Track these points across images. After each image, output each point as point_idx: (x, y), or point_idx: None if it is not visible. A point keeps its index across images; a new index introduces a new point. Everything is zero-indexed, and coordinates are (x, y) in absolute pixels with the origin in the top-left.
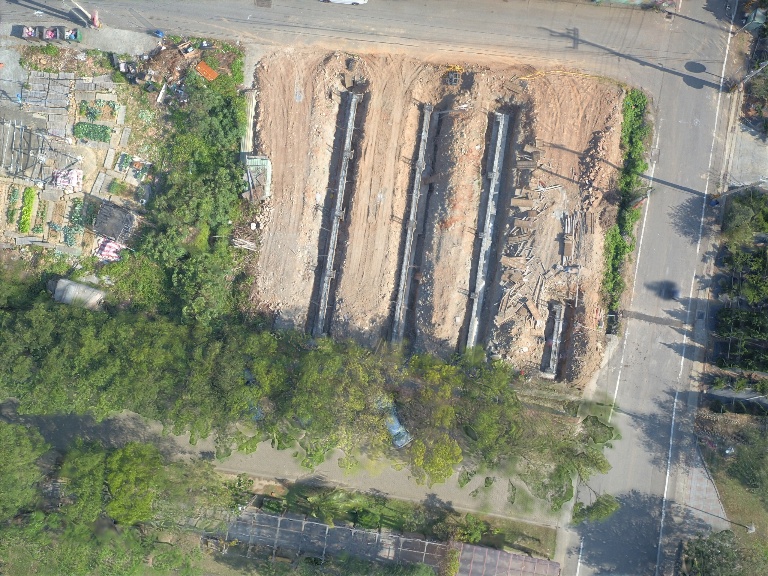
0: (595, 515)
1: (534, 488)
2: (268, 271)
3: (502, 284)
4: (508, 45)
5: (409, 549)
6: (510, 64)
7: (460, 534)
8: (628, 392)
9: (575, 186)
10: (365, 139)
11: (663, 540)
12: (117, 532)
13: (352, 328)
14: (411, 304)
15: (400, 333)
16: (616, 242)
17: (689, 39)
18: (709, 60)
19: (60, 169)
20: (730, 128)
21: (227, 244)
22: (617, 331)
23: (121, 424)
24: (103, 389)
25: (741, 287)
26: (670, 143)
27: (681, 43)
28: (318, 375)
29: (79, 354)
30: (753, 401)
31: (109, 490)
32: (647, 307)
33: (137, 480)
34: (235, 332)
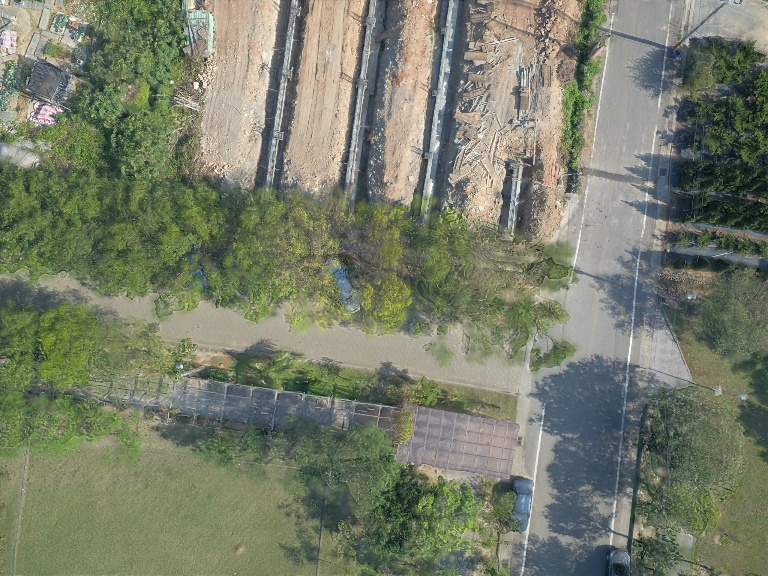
0: (552, 361)
1: (487, 332)
2: (212, 131)
3: (457, 142)
4: None
5: (362, 413)
6: None
7: (416, 398)
8: (589, 252)
9: (531, 38)
10: None
11: (628, 405)
12: (58, 408)
13: (301, 189)
14: (363, 168)
15: (352, 197)
16: (574, 98)
17: None
18: None
19: None
20: None
21: (169, 104)
22: (577, 190)
23: (61, 296)
24: (35, 244)
25: (703, 138)
26: None
27: None
28: (260, 220)
29: (8, 206)
30: (718, 258)
31: (42, 348)
32: (607, 164)
33: (72, 338)
34: (176, 189)
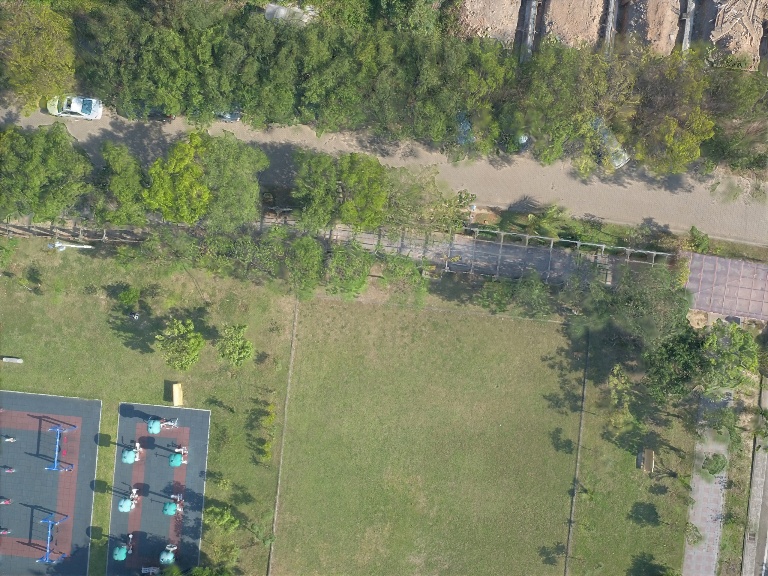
0: None
1: None
2: None
3: (716, 1)
4: None
5: None
6: None
7: (687, 246)
8: None
9: None
10: None
11: None
12: None
13: (565, 48)
14: (618, 31)
15: None
16: None
17: None
18: None
19: None
20: None
21: None
22: None
23: None
24: (331, 91)
25: None
26: None
27: None
28: (558, 60)
29: (308, 54)
30: None
31: (343, 189)
32: None
33: (370, 180)
34: None
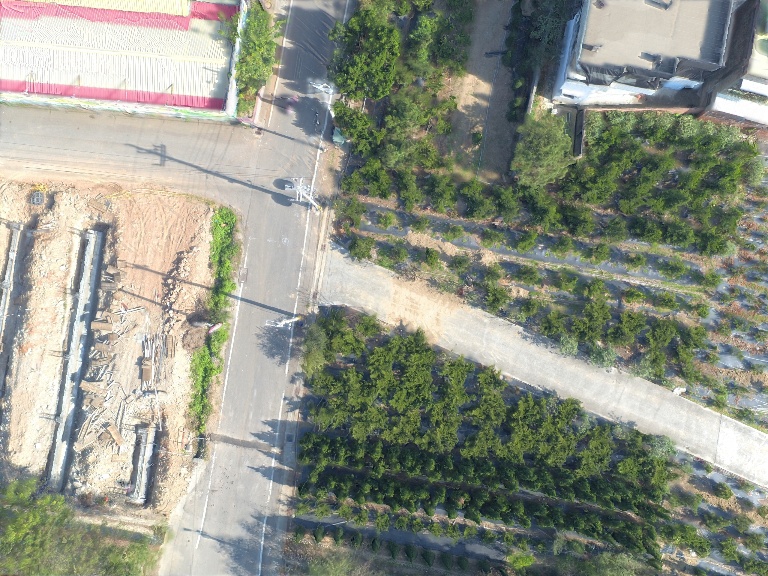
0: None
1: None
2: None
3: (85, 409)
4: (94, 162)
5: None
6: (96, 182)
7: None
8: (216, 517)
9: (158, 308)
10: None
11: None
12: None
13: None
14: None
15: None
16: (204, 363)
17: (277, 156)
18: (297, 177)
19: None
20: (320, 246)
21: None
22: (205, 455)
23: None
24: None
25: (319, 412)
26: (258, 262)
27: (269, 160)
28: None
29: None
30: (338, 526)
31: None
32: (235, 430)
33: None
34: None
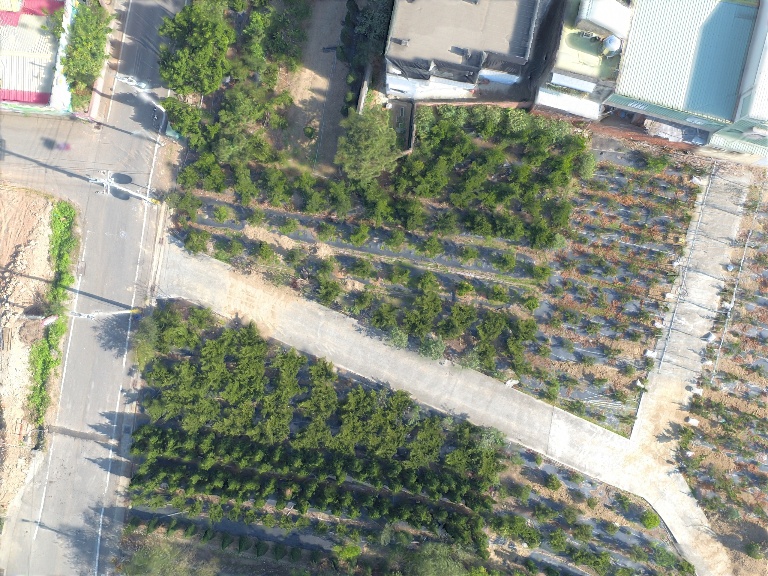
0: None
1: None
2: None
3: None
4: None
5: None
6: None
7: None
8: (53, 508)
9: None
10: None
11: None
12: None
13: None
14: None
15: None
16: (43, 356)
17: (116, 150)
18: (135, 171)
19: None
20: (158, 240)
21: None
22: (43, 446)
23: None
24: None
25: (152, 404)
26: (96, 255)
27: (108, 154)
28: None
29: None
30: (173, 517)
31: None
32: (72, 422)
33: None
34: None
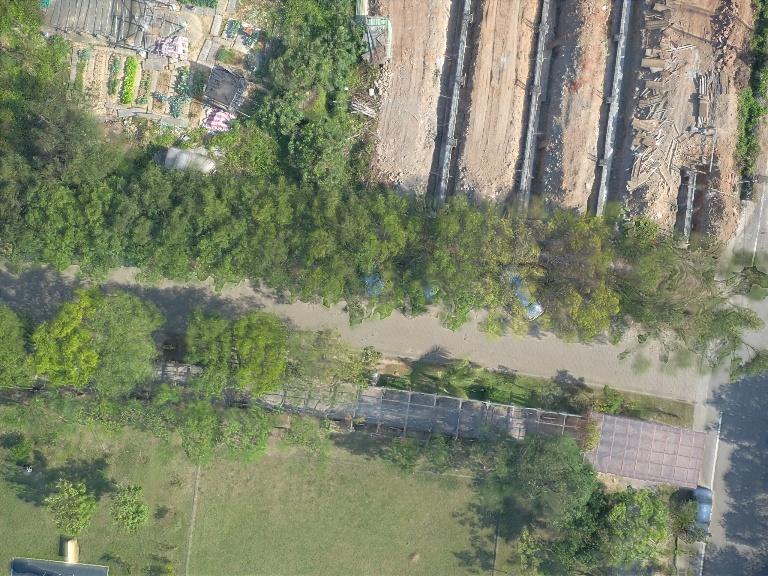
0: (756, 370)
1: (694, 341)
2: (388, 138)
3: (633, 149)
4: None
5: (547, 422)
6: None
7: (599, 406)
8: (765, 260)
9: (708, 46)
10: (486, 1)
11: None
12: (232, 417)
13: (478, 196)
14: (535, 175)
15: (525, 204)
16: (749, 105)
17: None
18: None
19: (164, 37)
20: None
21: (344, 110)
22: (753, 197)
23: (233, 304)
24: (228, 252)
25: None
26: None
27: None
28: (462, 228)
29: (203, 214)
30: None
31: (238, 357)
32: None
33: (267, 346)
34: (361, 196)
